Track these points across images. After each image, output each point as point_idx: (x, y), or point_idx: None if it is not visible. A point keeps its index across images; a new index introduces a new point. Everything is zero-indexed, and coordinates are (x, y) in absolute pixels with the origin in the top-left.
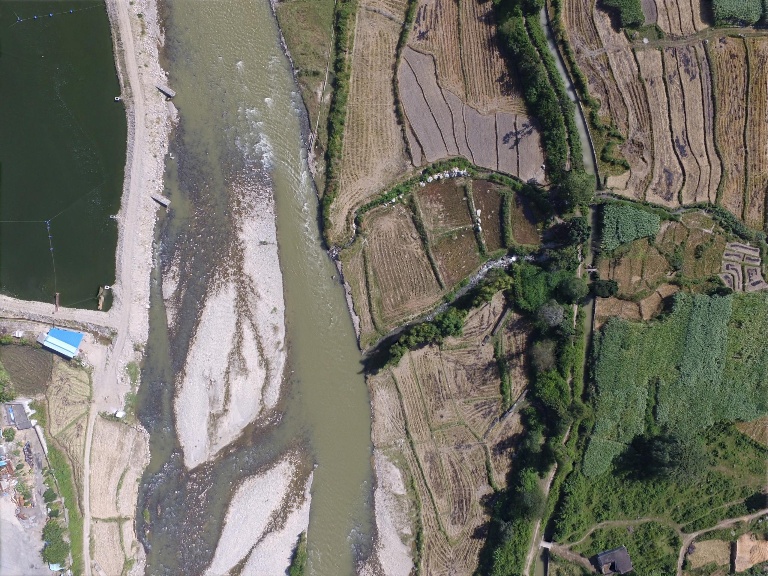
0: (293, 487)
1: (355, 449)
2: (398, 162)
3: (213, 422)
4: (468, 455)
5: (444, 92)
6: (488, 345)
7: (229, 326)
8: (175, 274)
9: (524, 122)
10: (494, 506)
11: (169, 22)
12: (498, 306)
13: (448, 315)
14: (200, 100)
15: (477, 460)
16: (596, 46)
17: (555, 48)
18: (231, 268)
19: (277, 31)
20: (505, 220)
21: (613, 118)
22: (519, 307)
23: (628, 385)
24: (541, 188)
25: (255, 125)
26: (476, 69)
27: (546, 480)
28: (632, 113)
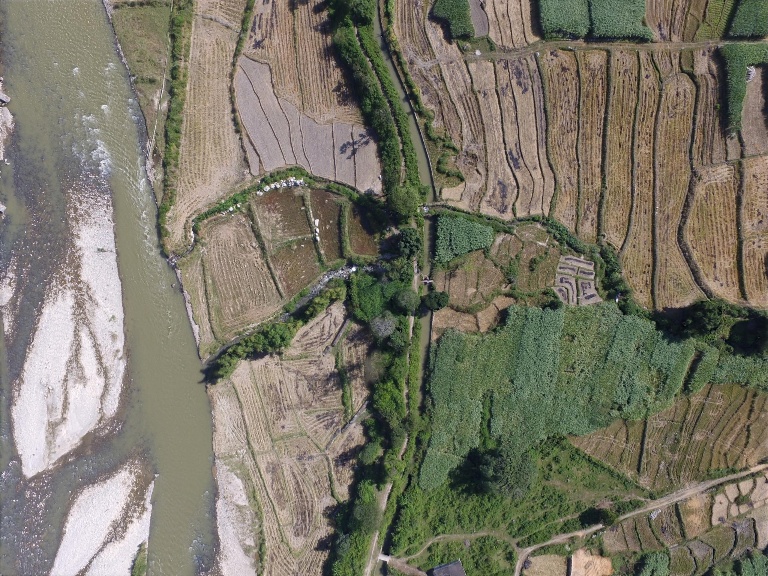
0: (133, 497)
1: (196, 459)
2: (236, 171)
3: (51, 430)
4: (311, 466)
5: (281, 101)
6: (329, 356)
7: (67, 334)
8: (11, 281)
9: (361, 132)
10: (335, 518)
11: (3, 27)
12: (339, 316)
13: (275, 326)
14: (36, 106)
15: (320, 471)
16: (429, 57)
17: (390, 59)
18: (68, 275)
19: (113, 38)
20: (342, 230)
21: (447, 129)
22: (356, 318)
23: (462, 398)
24: (378, 199)
25: (92, 132)
26: (312, 78)
27: (383, 492)
28: (466, 125)
